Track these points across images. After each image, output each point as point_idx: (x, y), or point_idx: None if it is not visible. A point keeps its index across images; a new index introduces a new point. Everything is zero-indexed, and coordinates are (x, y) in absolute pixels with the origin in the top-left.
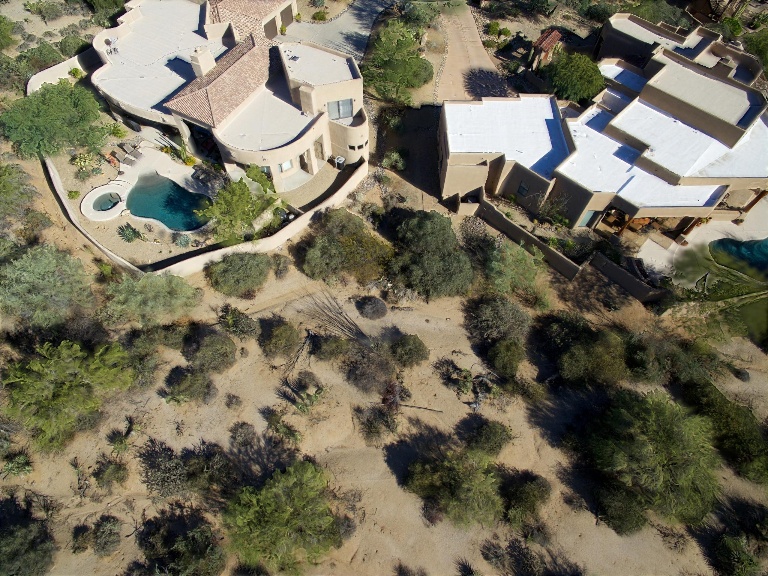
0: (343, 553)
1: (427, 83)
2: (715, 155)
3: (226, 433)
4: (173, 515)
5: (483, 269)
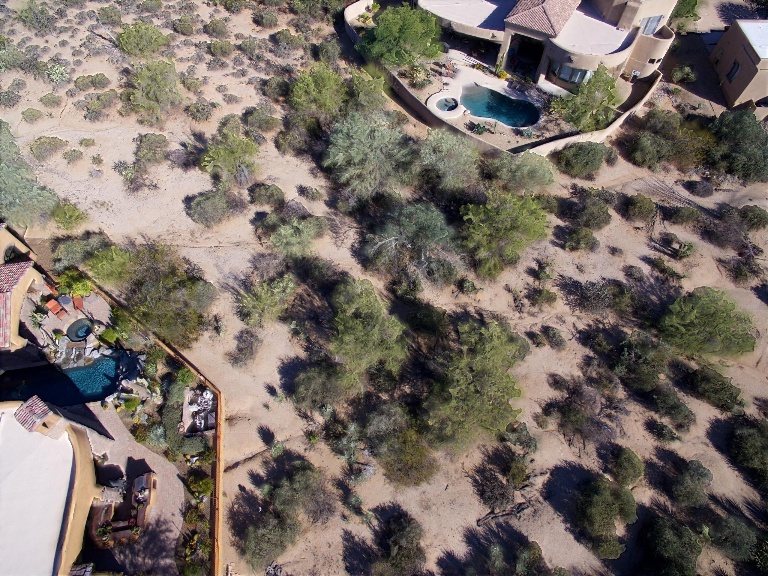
0: (749, 359)
1: (689, 13)
2: None
3: (619, 272)
4: (598, 328)
5: None
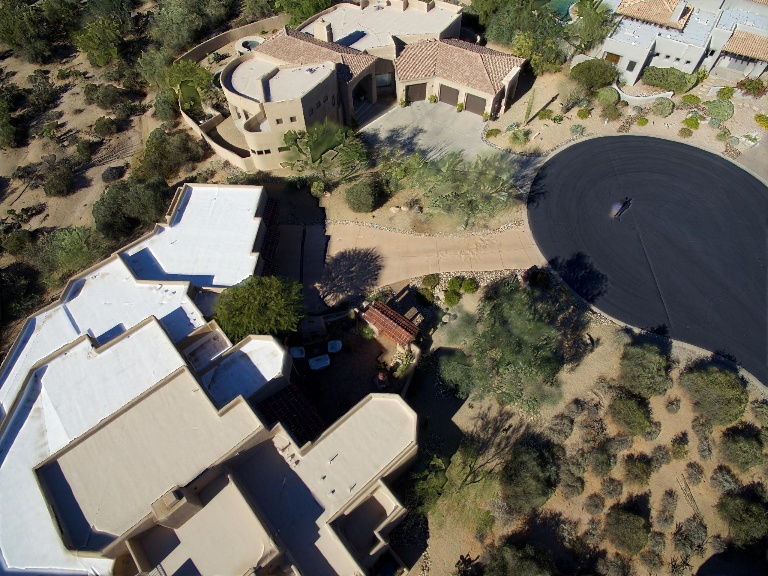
0: None
1: None
2: (56, 443)
3: None
4: None
5: (115, 247)
